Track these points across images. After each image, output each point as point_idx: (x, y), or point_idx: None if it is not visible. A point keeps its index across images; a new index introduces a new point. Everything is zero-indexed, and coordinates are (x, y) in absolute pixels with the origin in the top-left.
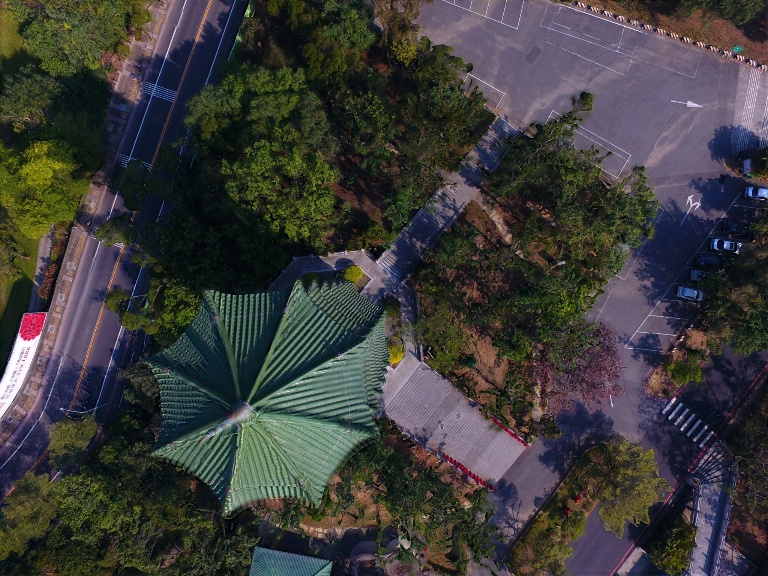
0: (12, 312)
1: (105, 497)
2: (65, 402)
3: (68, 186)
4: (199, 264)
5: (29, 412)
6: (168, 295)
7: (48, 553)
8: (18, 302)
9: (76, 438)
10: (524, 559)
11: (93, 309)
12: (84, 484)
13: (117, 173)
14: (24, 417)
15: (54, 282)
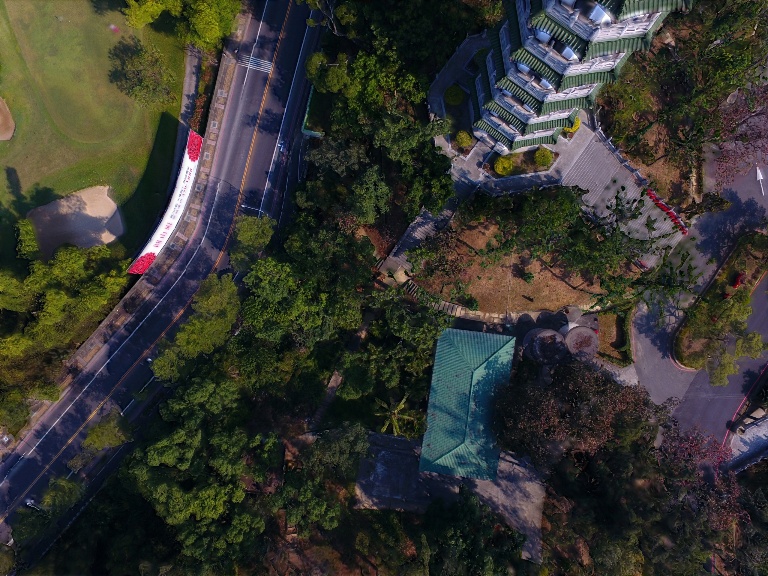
0: (159, 153)
1: (293, 285)
2: (225, 226)
3: (226, 0)
4: (400, 15)
5: (190, 238)
6: (356, 67)
7: (231, 356)
8: (164, 143)
9: (256, 237)
10: (696, 332)
11: (246, 134)
12: (274, 270)
13: (260, 0)
14: (186, 243)
15: (204, 114)
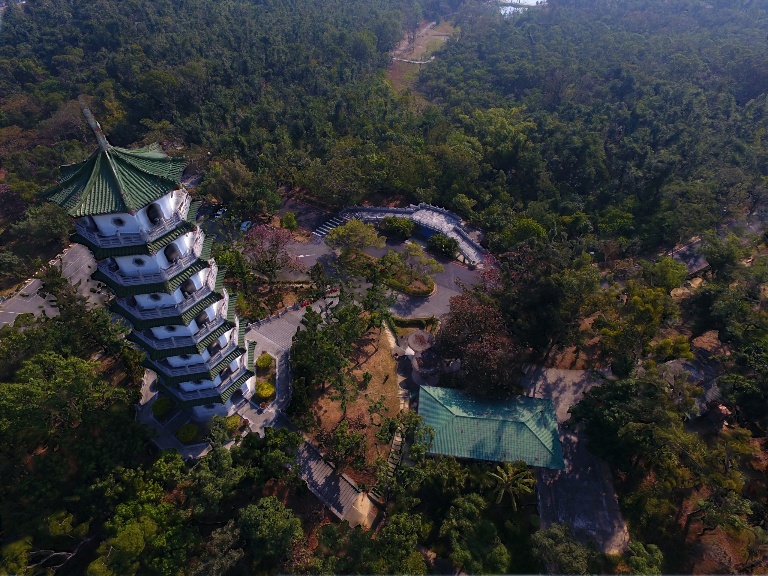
0: None
1: None
2: None
3: None
4: None
5: None
6: (122, 527)
7: None
8: None
9: None
10: (408, 279)
11: None
12: None
13: None
14: None
15: None
